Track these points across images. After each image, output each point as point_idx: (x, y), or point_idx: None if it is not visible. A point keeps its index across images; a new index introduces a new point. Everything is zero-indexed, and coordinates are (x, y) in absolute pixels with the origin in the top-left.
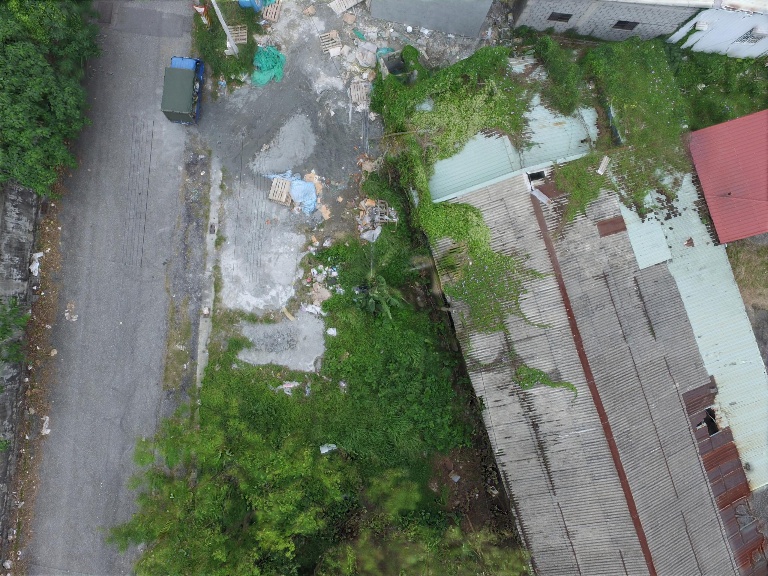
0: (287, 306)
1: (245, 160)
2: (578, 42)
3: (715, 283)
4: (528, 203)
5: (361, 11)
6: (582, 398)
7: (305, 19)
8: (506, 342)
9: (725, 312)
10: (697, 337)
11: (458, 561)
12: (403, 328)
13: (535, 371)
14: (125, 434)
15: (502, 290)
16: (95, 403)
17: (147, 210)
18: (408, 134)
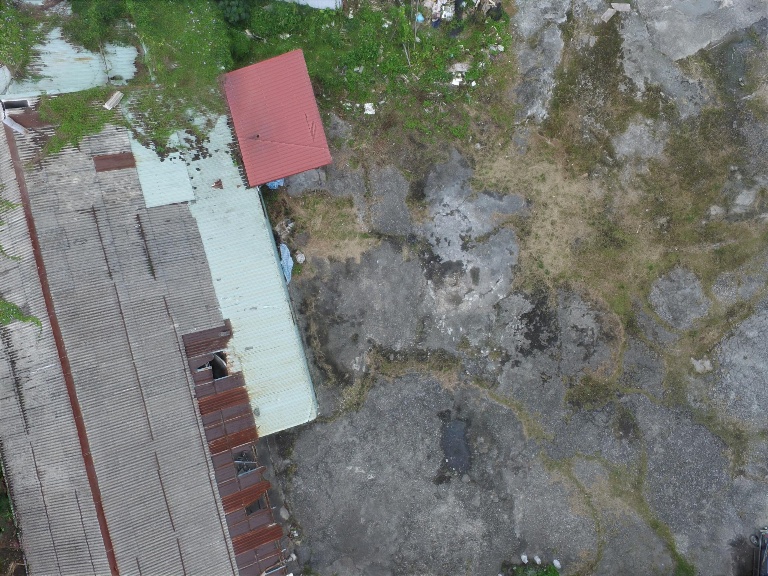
0: None
1: None
2: None
3: (242, 226)
4: (2, 131)
5: None
6: (46, 332)
7: None
8: None
9: (251, 256)
10: (216, 280)
11: (8, 513)
12: None
13: (10, 305)
14: None
15: None
16: None
17: None
18: None
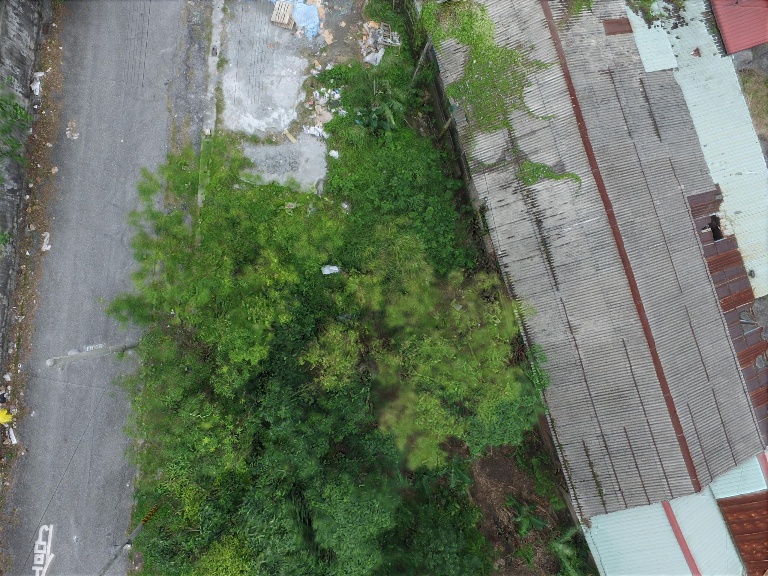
0: (289, 129)
1: None
2: None
3: (721, 94)
4: None
5: None
6: (586, 187)
7: None
8: (510, 139)
9: (731, 123)
10: (703, 146)
11: None
12: (406, 148)
13: (539, 165)
14: (126, 250)
15: (506, 85)
16: (96, 219)
17: (149, 30)
18: None
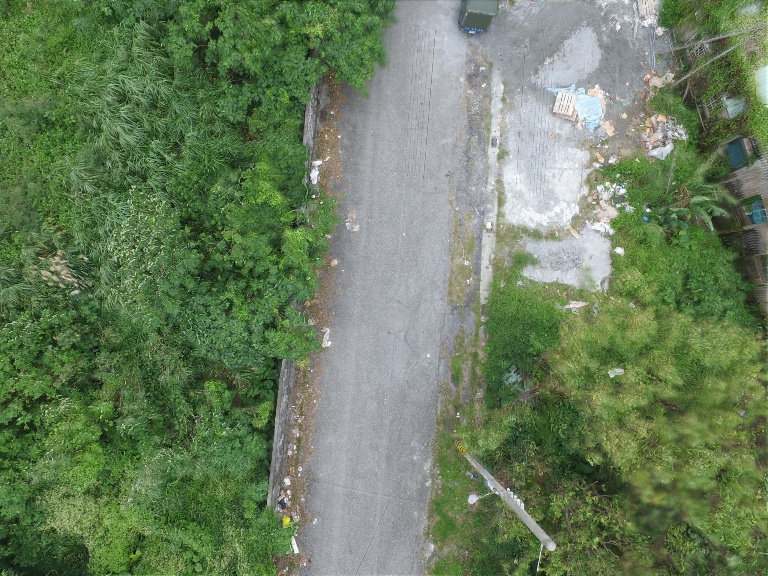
0: (572, 223)
1: (527, 73)
2: None
3: None
4: None
5: None
6: None
7: None
8: None
9: None
10: None
11: None
12: (700, 248)
13: None
14: (410, 349)
15: None
16: (378, 316)
17: (429, 120)
18: (731, 38)
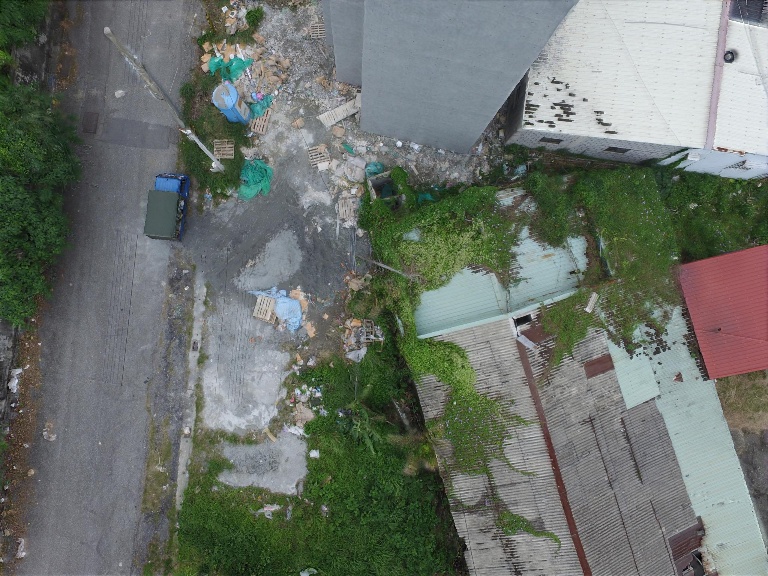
0: (270, 426)
1: (230, 275)
2: (570, 159)
3: (704, 419)
4: (514, 348)
5: (350, 124)
6: (565, 550)
7: (293, 132)
8: (490, 486)
9: (713, 449)
10: (684, 476)
11: None
12: (387, 453)
13: (518, 518)
14: (101, 559)
15: (486, 433)
16: (72, 526)
17: (129, 327)
18: (394, 265)
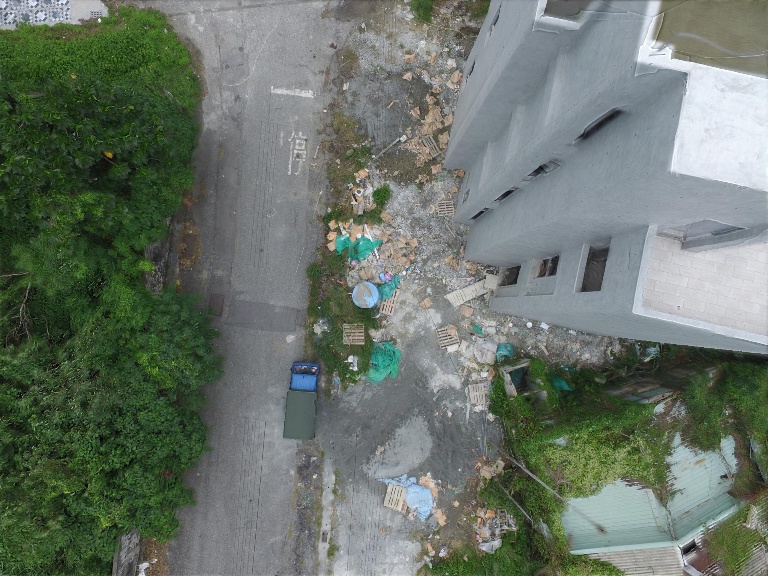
0: None
1: (359, 462)
2: None
3: None
4: None
5: (479, 303)
6: None
7: (421, 311)
8: None
9: None
10: None
11: None
12: None
13: None
14: None
15: None
16: None
17: (258, 519)
18: (542, 473)
